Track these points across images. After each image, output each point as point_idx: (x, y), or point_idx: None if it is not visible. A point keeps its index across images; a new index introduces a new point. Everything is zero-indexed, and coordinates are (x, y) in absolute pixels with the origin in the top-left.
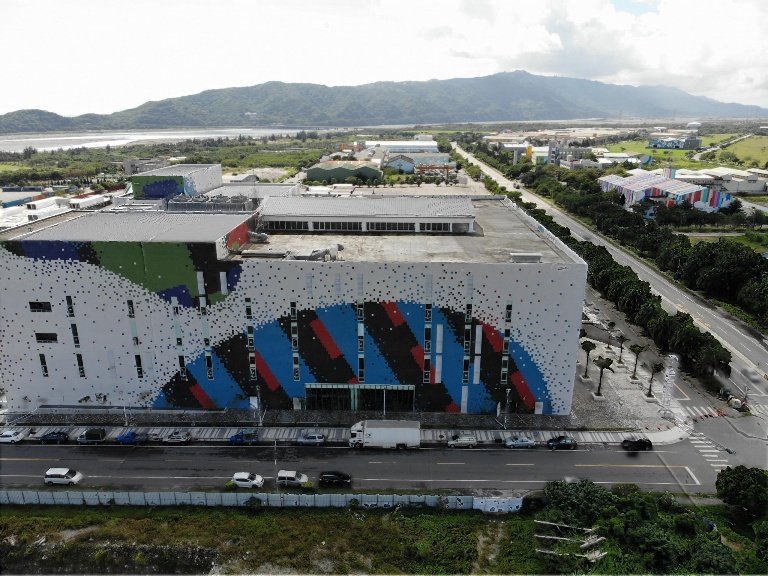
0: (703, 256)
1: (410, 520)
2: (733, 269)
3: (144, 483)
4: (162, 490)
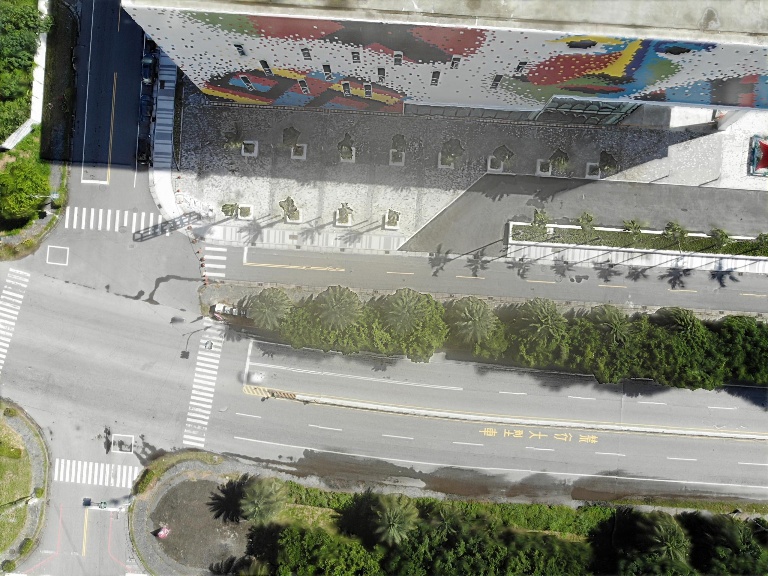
0: (742, 568)
1: None
2: (632, 568)
3: None
4: None
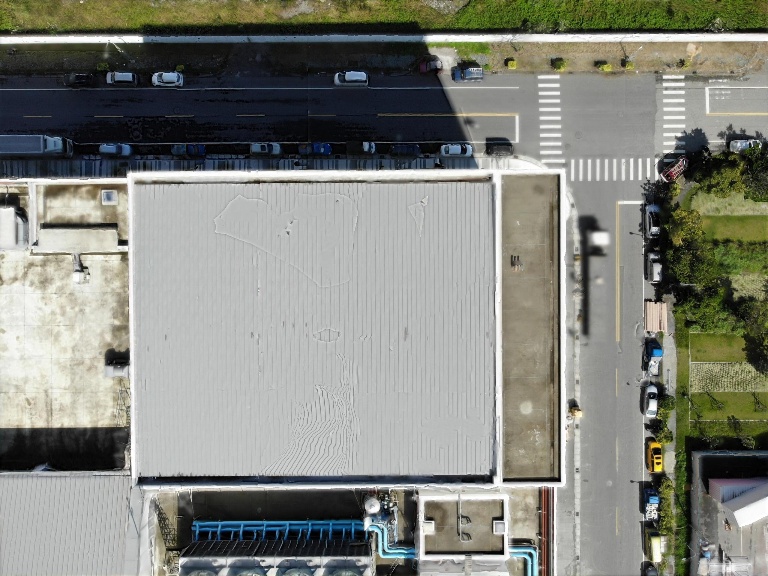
0: None
1: (7, 27)
2: None
3: (271, 79)
4: (249, 69)
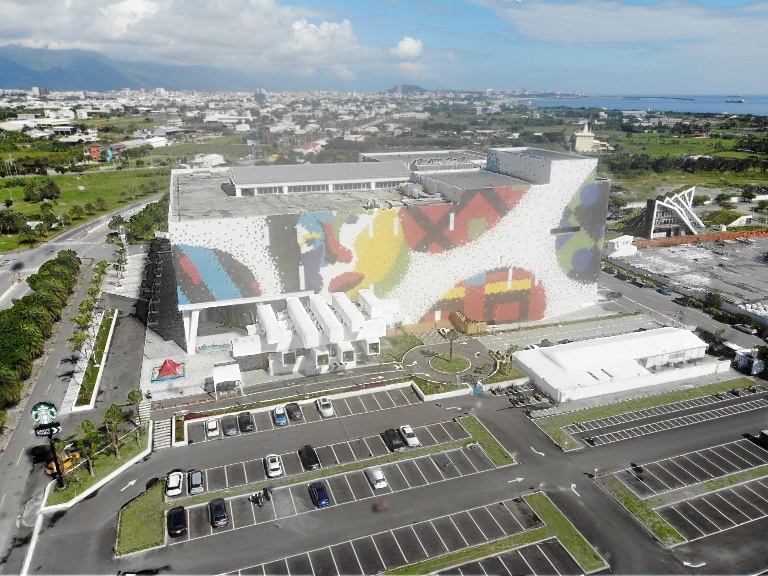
0: None
1: None
2: None
3: None
4: None
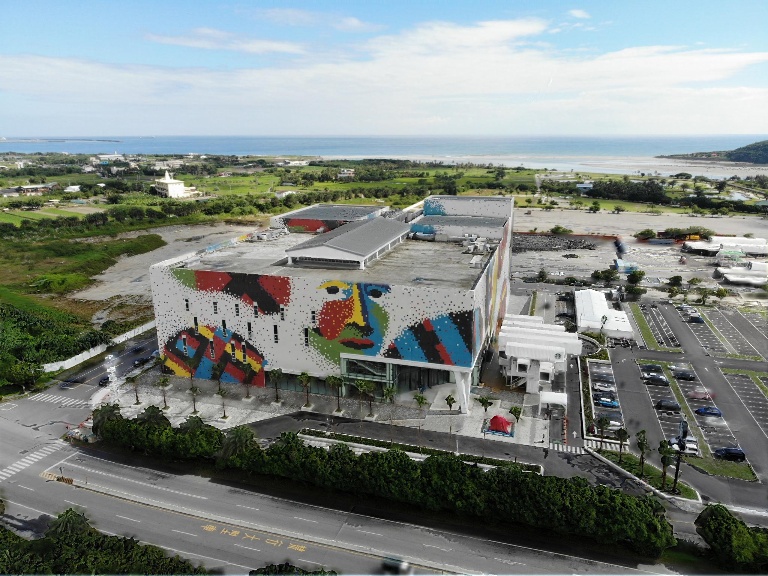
0: None
1: None
2: None
3: None
4: None
